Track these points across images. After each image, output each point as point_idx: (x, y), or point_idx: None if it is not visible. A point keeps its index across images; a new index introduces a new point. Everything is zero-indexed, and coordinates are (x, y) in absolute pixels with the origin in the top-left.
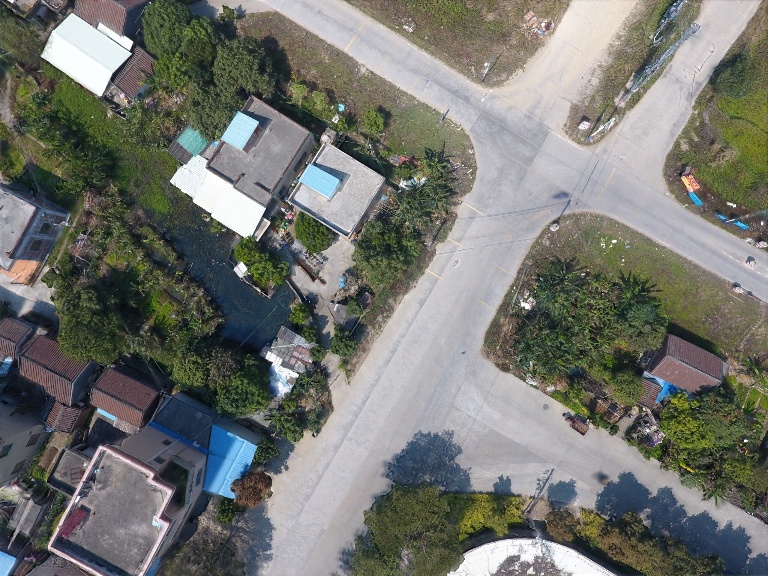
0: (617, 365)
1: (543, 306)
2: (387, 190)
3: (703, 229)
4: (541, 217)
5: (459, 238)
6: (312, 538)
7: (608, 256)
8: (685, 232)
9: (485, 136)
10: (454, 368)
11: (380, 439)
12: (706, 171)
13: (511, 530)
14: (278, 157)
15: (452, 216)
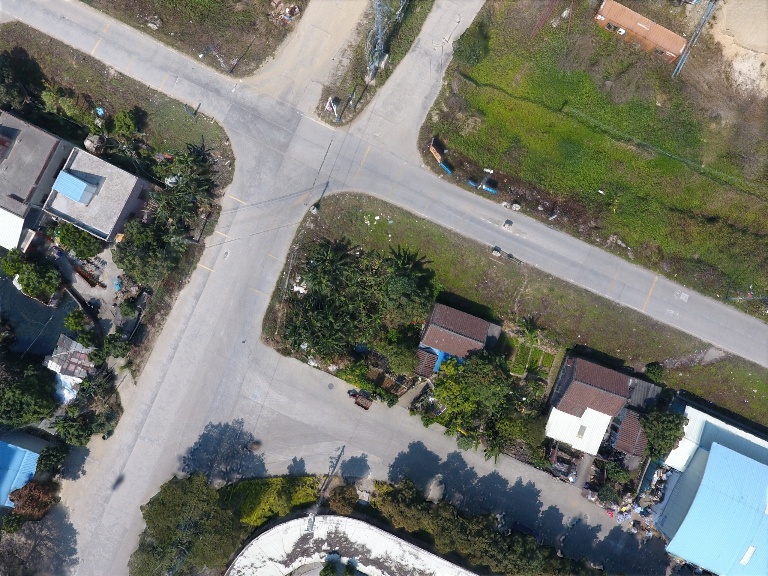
0: (402, 338)
1: (313, 288)
2: (154, 189)
3: (460, 197)
4: (303, 201)
5: (226, 230)
6: (116, 538)
7: (375, 233)
8: (443, 202)
9: (239, 126)
10: (236, 358)
11: (172, 435)
12: (458, 140)
13: (307, 509)
14: (30, 167)
15: (216, 209)
